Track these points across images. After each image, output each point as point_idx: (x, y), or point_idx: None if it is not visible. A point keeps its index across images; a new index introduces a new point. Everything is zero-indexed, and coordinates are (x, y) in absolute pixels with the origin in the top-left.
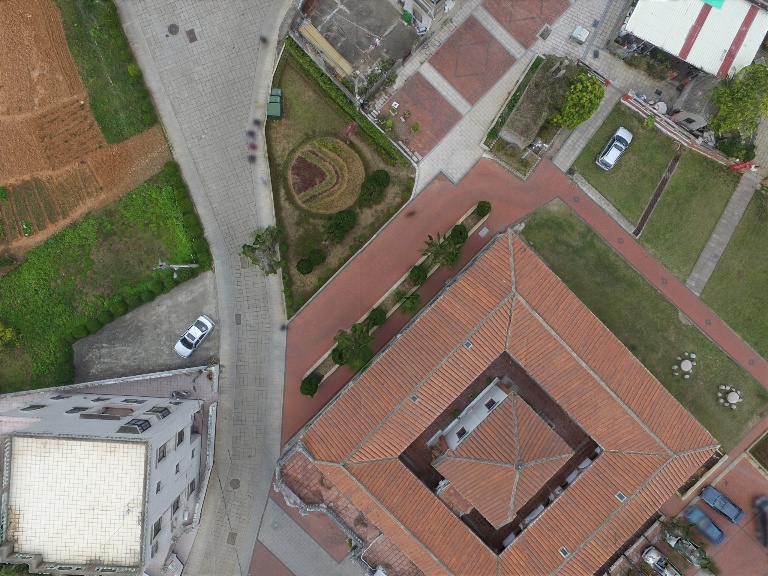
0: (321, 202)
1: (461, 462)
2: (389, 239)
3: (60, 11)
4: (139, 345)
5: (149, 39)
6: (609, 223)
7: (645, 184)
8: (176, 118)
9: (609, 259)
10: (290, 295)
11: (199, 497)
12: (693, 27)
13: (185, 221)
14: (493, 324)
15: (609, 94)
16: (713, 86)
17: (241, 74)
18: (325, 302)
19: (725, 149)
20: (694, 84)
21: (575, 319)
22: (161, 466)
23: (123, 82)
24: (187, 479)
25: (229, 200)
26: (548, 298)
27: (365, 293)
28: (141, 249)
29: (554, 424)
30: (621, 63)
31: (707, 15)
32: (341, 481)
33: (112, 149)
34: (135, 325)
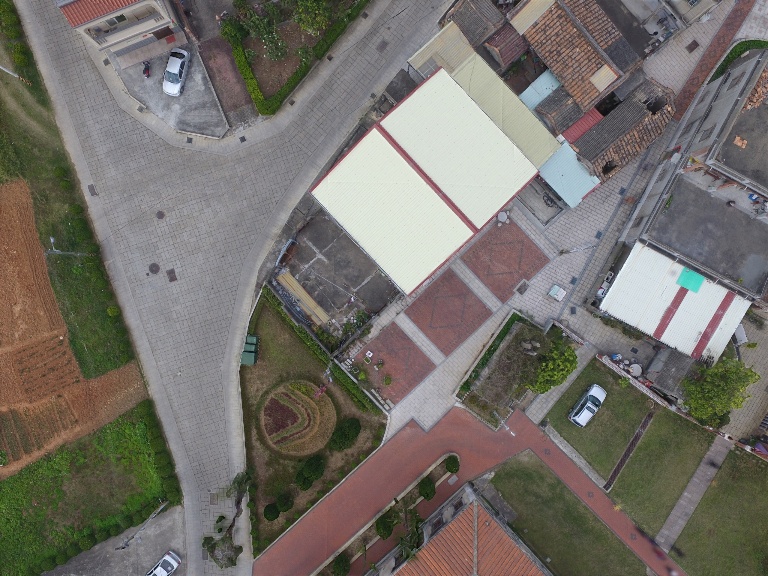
0: (292, 444)
1: None
2: (358, 483)
3: (44, 248)
4: None
5: (130, 277)
6: (580, 476)
7: (618, 439)
8: (153, 355)
9: (578, 511)
10: (257, 535)
11: None
12: (668, 309)
13: (156, 462)
14: None
15: (584, 350)
16: (687, 365)
17: (218, 314)
18: (292, 542)
19: (699, 418)
20: (668, 358)
21: None
22: None
23: (102, 319)
24: None
25: (201, 437)
26: (510, 575)
27: (332, 535)
28: (112, 482)
29: None
30: (598, 320)
31: (683, 298)
32: None
33: (89, 383)
34: (103, 556)
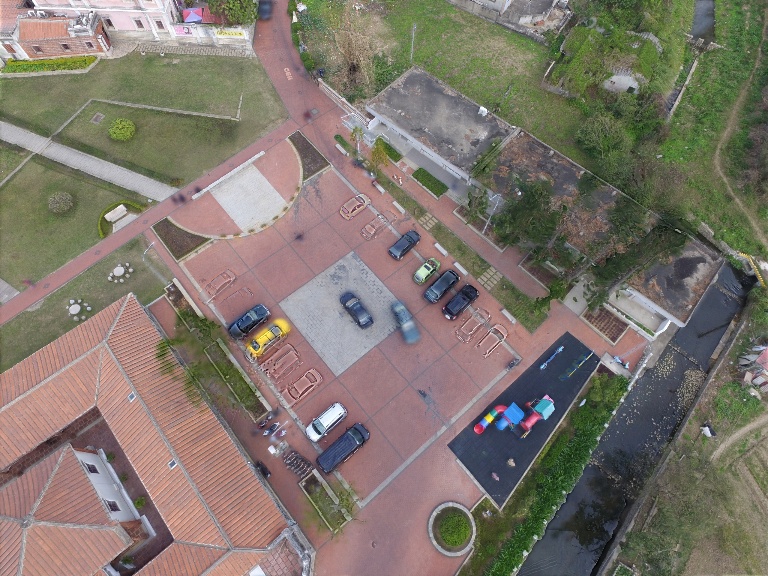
0: None
1: None
2: None
3: None
4: None
5: None
6: None
7: None
8: None
9: None
10: None
11: None
12: None
13: None
14: None
15: None
16: None
17: None
18: None
19: None
20: None
21: None
22: None
23: None
24: None
25: None
26: None
27: None
28: None
29: (86, 447)
30: None
31: None
32: None
33: None
34: None
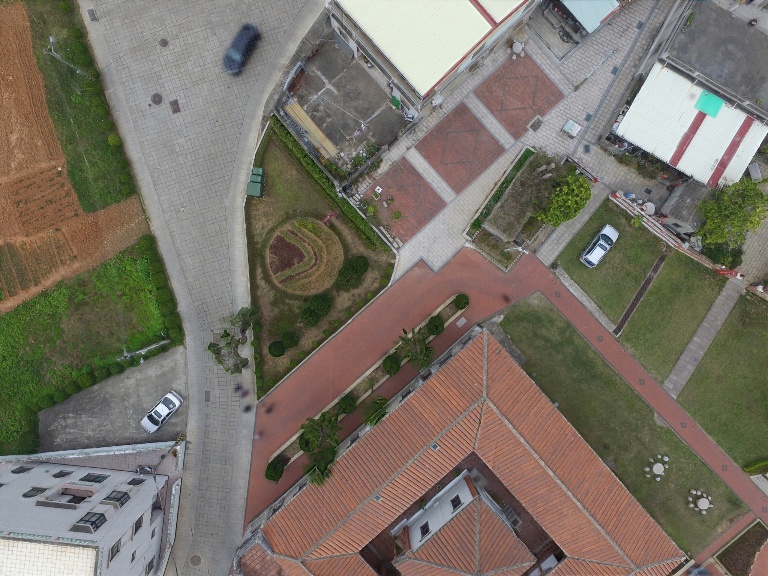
0: (298, 283)
1: (421, 565)
2: (365, 324)
3: (41, 74)
4: (106, 417)
5: (131, 107)
6: (589, 320)
7: (628, 283)
8: (155, 189)
9: (587, 356)
10: (261, 376)
11: (158, 575)
12: (686, 134)
13: (158, 296)
14: (462, 427)
15: (597, 190)
16: (702, 195)
17: (223, 148)
18: (296, 384)
19: (711, 256)
20: (683, 190)
21: (546, 425)
22: (114, 562)
23: (102, 150)
24: (145, 561)
25: (204, 275)
26: (520, 403)
27: (337, 377)
28: (112, 320)
29: (521, 520)
30: (612, 159)
31: (701, 123)
32: (299, 575)
33: (88, 217)
34: (103, 396)
